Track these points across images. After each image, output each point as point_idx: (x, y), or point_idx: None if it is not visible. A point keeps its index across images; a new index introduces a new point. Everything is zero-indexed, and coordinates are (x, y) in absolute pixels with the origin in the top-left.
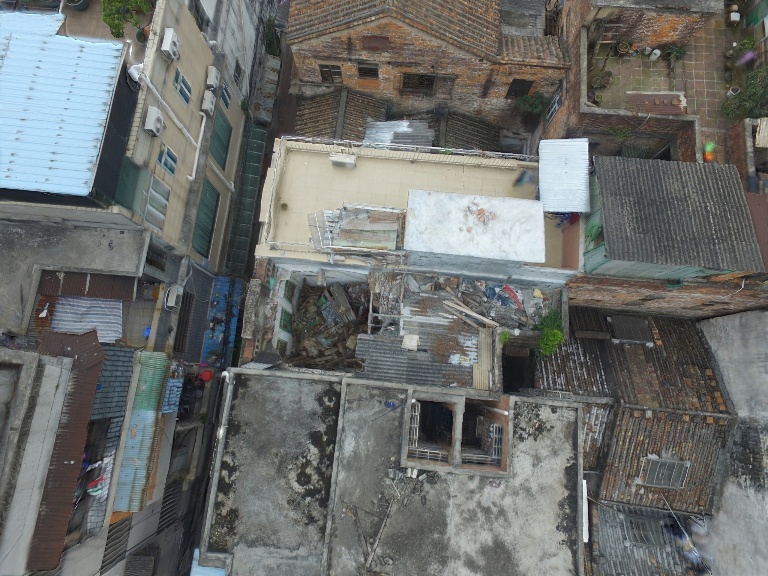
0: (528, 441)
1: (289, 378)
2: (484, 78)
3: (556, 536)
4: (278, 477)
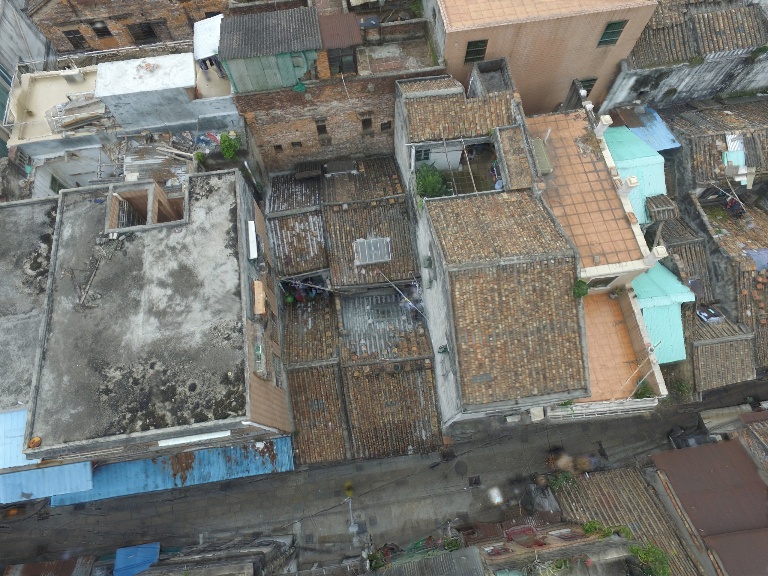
0: (202, 200)
1: (24, 206)
2: (185, 17)
3: (225, 252)
4: (15, 269)
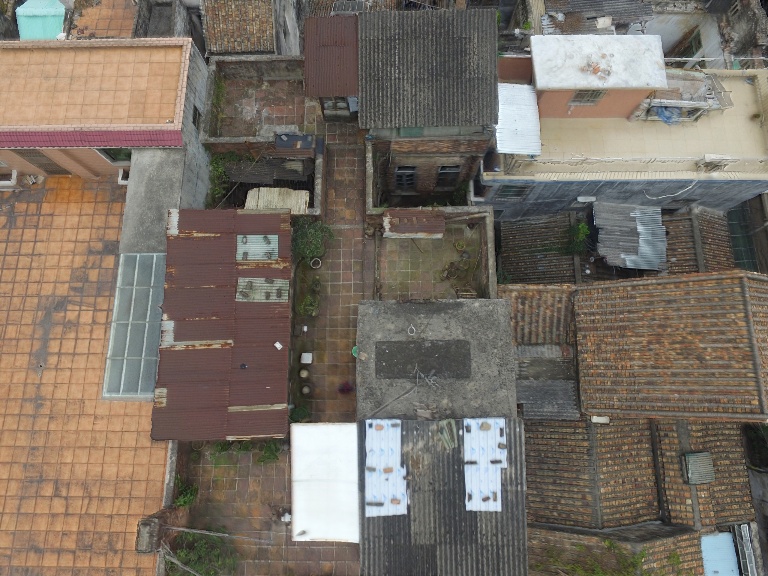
0: None
1: None
2: None
3: None
4: None
